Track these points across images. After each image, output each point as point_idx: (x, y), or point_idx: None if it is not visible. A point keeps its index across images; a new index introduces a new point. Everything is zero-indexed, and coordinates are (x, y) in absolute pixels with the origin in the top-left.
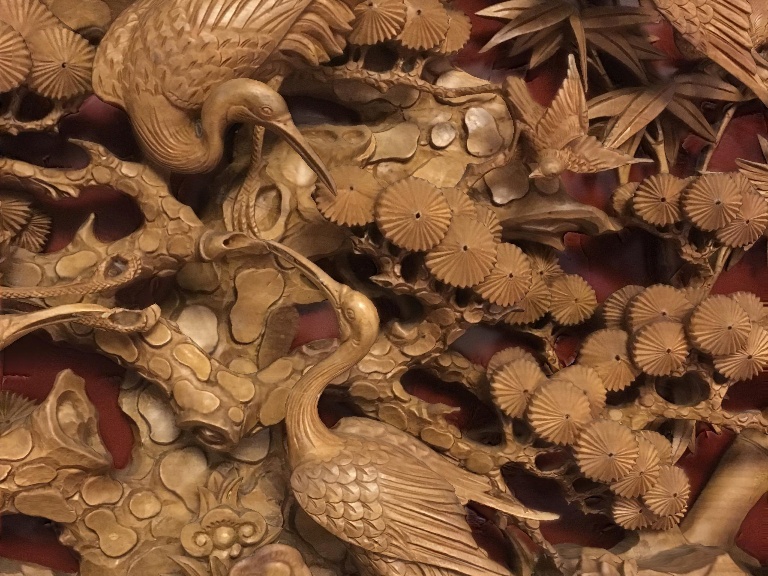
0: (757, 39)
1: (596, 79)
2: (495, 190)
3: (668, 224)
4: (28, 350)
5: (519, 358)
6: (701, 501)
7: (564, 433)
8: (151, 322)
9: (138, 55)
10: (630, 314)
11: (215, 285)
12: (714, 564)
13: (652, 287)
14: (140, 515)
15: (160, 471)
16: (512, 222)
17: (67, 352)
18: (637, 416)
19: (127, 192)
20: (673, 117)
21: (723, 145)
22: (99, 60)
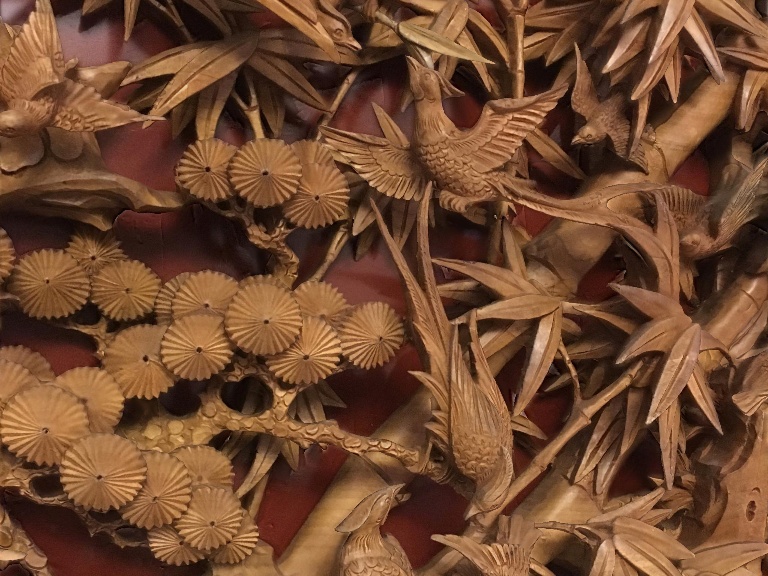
0: None
1: (172, 31)
2: (3, 154)
3: (221, 199)
4: None
5: (20, 359)
6: (305, 526)
7: (45, 451)
8: None
9: None
10: (171, 306)
11: None
12: None
13: (198, 274)
14: None
15: None
16: (24, 194)
17: None
18: (198, 428)
19: None
20: (265, 78)
21: (340, 115)
22: None
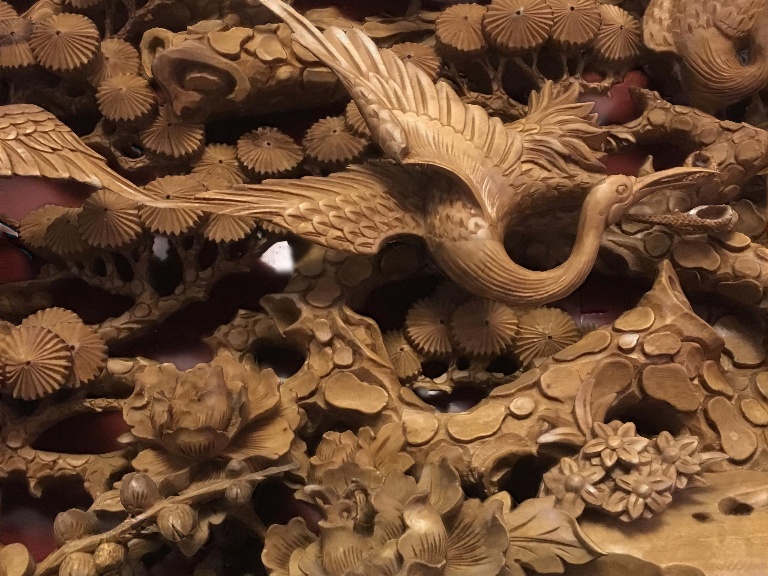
0: None
1: None
2: None
3: None
4: (601, 289)
5: None
6: None
7: None
8: (734, 219)
9: (686, 3)
10: None
11: (762, 228)
12: None
13: None
14: (753, 419)
15: (758, 386)
16: None
17: (640, 284)
18: None
19: (682, 128)
20: None
21: None
22: (648, 22)
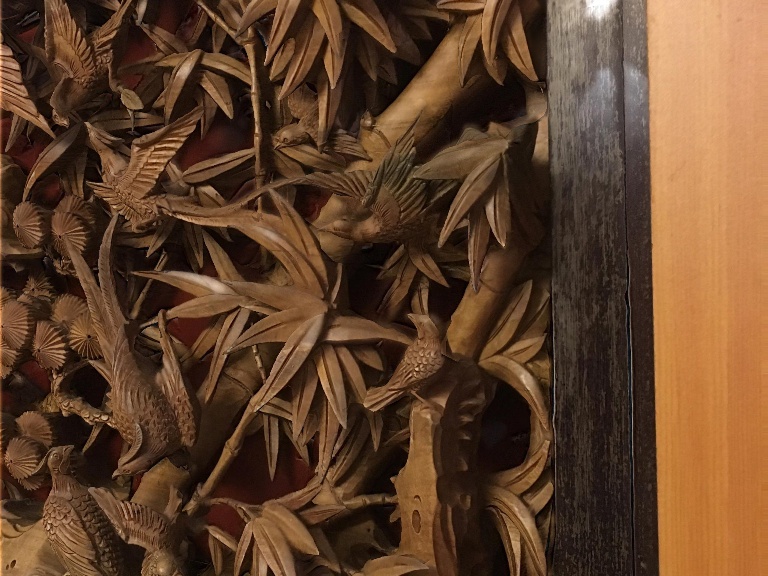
0: (82, 79)
1: None
2: None
3: None
4: None
5: None
6: None
7: None
8: None
9: None
10: None
11: None
12: (36, 522)
13: None
14: None
15: None
16: None
17: None
18: (51, 401)
19: None
20: None
21: None
22: None
